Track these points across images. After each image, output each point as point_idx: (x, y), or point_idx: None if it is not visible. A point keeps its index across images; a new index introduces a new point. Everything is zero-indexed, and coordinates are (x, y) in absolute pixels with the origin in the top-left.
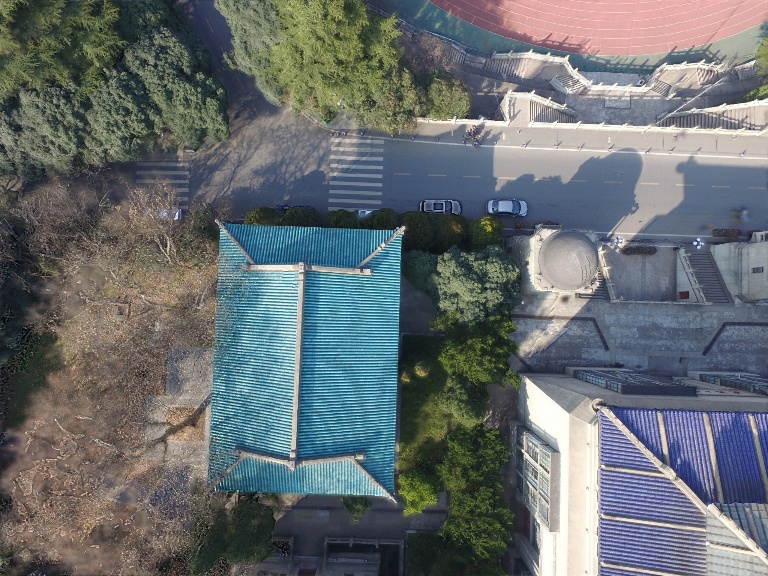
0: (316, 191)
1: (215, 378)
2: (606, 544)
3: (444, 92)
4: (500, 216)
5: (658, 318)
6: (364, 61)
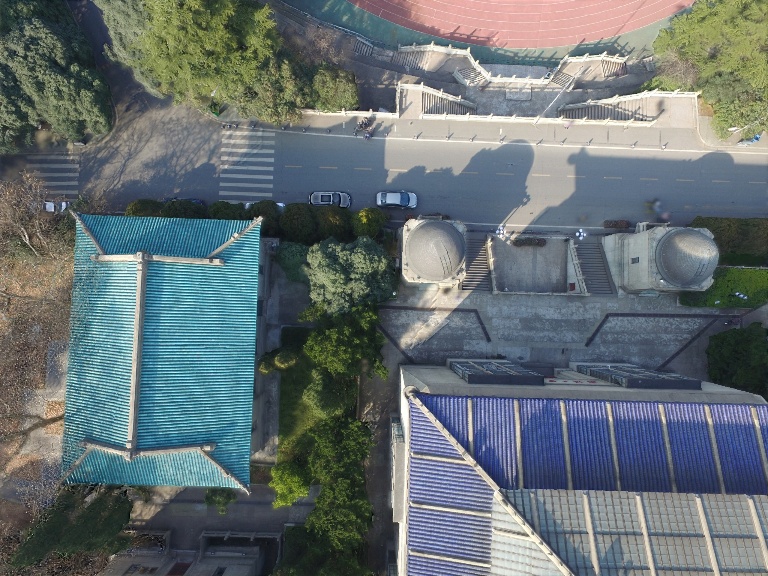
0: (206, 184)
1: (69, 370)
2: (414, 532)
3: (327, 83)
4: (390, 208)
5: (541, 309)
6: (238, 52)
